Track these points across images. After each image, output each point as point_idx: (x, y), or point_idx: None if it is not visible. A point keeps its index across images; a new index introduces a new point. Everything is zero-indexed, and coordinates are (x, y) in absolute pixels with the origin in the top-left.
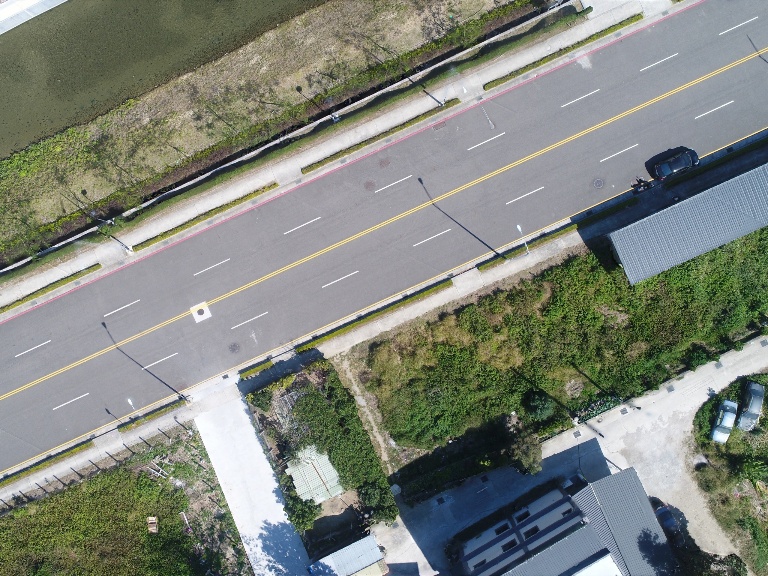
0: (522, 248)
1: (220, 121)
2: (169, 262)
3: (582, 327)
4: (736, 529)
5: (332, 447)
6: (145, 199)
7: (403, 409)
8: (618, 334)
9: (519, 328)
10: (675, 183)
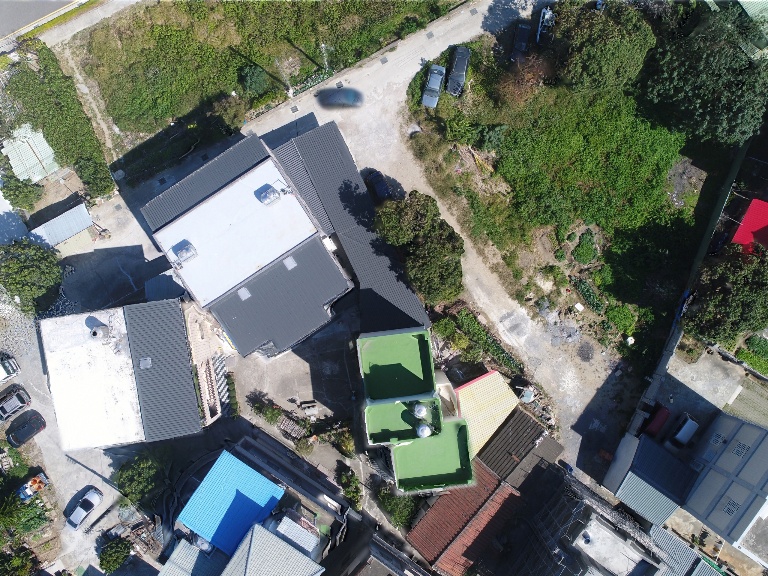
0: None
1: None
2: None
3: (295, 2)
4: (451, 196)
5: (45, 123)
6: None
7: (124, 93)
8: (330, 6)
9: (233, 5)
10: None
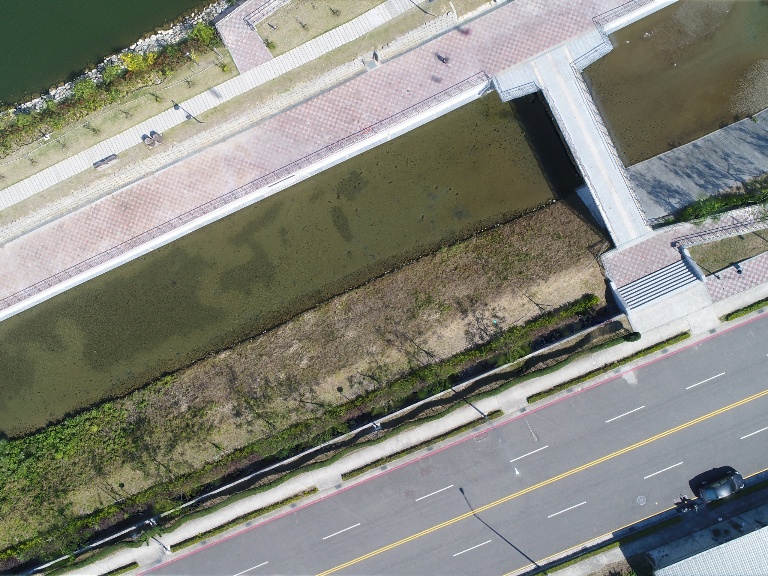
0: (563, 564)
1: (260, 419)
2: (207, 562)
3: None
4: None
5: None
6: (184, 500)
7: None
8: None
9: None
10: (719, 504)
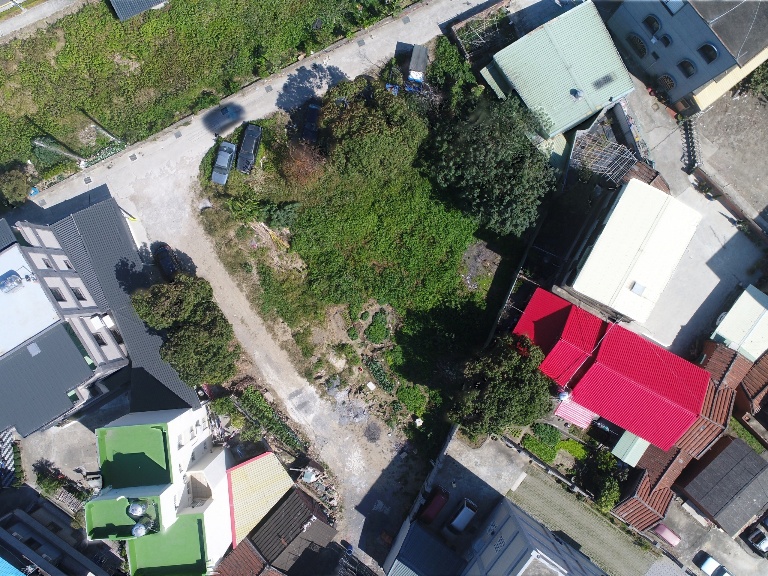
0: None
1: None
2: None
3: (91, 73)
4: (241, 273)
5: None
6: None
7: None
8: (125, 79)
9: (29, 74)
10: None
